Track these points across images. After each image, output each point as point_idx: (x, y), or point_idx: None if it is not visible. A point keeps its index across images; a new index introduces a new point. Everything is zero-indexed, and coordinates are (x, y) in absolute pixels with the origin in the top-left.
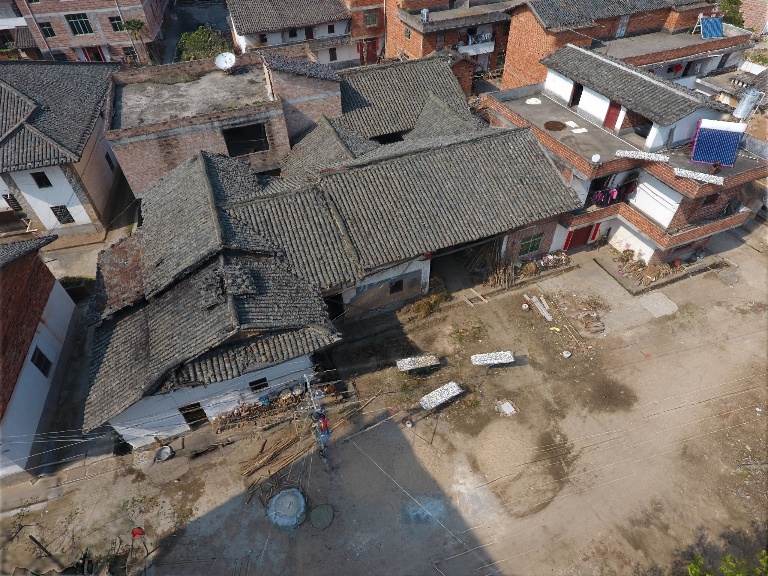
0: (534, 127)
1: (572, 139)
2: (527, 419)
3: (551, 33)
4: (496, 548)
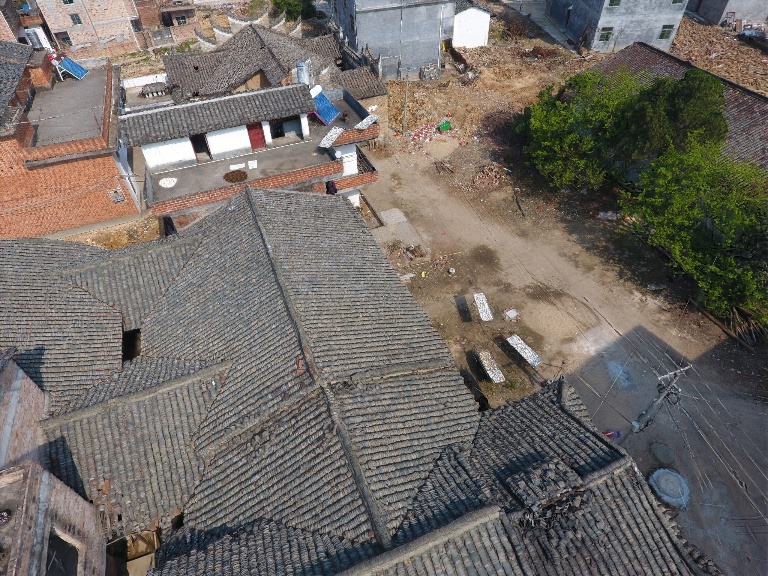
0: (253, 182)
1: (268, 171)
2: (518, 304)
3: (2, 139)
4: (627, 334)
